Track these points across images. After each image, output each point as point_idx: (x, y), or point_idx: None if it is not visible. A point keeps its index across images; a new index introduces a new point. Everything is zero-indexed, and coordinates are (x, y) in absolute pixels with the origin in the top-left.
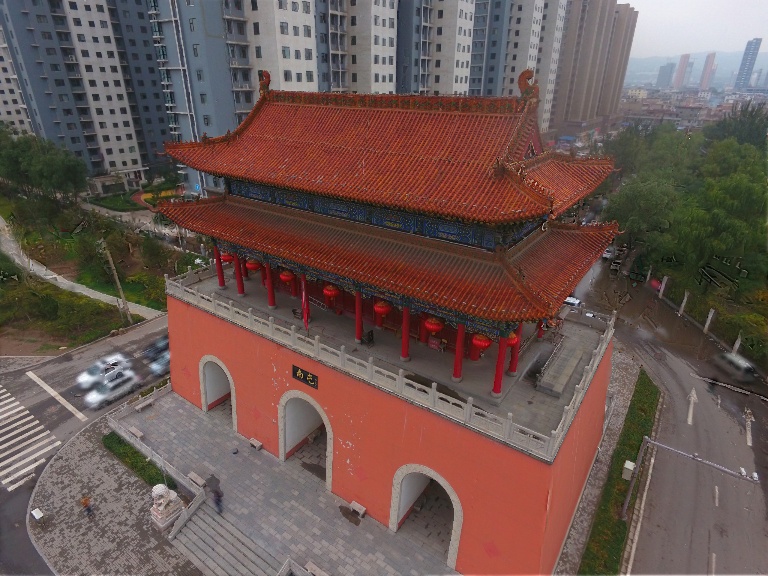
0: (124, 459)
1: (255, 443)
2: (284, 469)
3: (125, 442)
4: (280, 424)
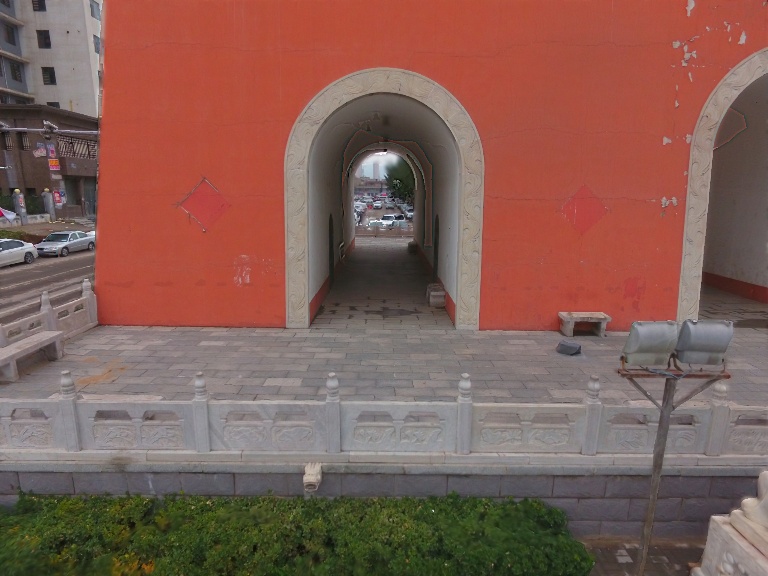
0: (96, 570)
1: (592, 314)
2: (734, 338)
3: (11, 501)
4: (694, 199)
